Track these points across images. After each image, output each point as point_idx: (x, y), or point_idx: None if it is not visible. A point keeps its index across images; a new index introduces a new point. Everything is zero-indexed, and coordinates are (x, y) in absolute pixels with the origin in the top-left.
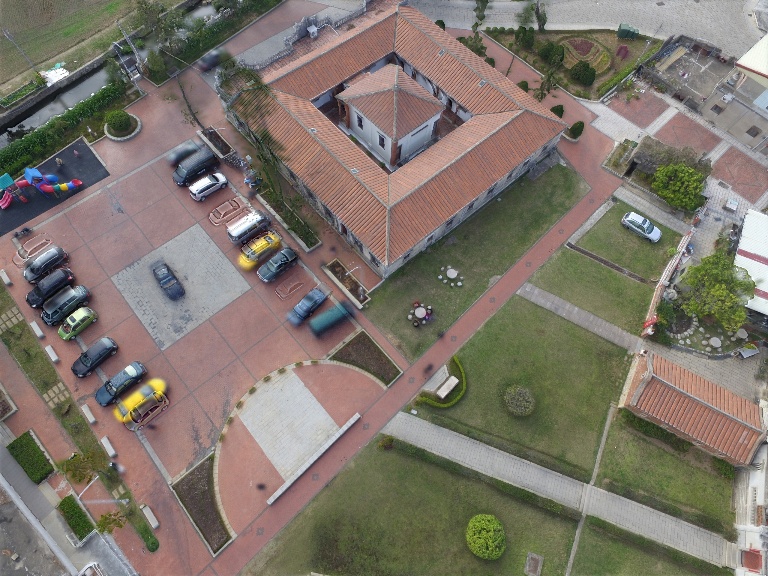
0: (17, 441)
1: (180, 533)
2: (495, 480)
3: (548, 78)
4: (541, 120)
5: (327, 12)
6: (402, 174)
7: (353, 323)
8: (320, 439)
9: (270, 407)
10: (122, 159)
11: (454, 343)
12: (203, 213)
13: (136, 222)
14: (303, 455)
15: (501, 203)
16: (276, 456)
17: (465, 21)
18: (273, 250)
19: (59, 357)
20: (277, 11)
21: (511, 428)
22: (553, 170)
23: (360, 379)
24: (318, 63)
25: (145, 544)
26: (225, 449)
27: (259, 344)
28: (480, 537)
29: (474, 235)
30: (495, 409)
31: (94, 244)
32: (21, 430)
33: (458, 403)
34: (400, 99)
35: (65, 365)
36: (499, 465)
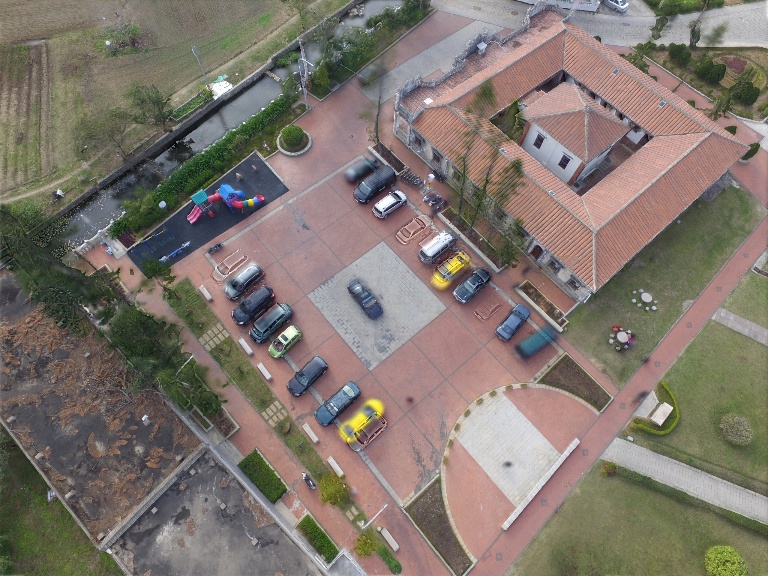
0: (248, 460)
1: (420, 556)
2: (726, 511)
3: (729, 100)
4: (726, 143)
5: (474, 26)
6: (595, 196)
7: (554, 346)
8: (542, 464)
9: (487, 430)
10: (298, 174)
11: (658, 369)
12: (387, 231)
13: (323, 239)
14: (528, 480)
15: (681, 225)
16: (501, 480)
17: (613, 37)
18: (462, 270)
19: (271, 375)
20: (425, 24)
21: (730, 457)
22: (727, 192)
23: (572, 404)
24: (495, 81)
25: (388, 567)
26: (450, 472)
27: (464, 366)
28: (725, 569)
29: (659, 258)
30: (711, 437)
31: (285, 261)
32: (246, 448)
33: (673, 430)
34: (591, 120)
35: (278, 383)
36: (724, 495)
